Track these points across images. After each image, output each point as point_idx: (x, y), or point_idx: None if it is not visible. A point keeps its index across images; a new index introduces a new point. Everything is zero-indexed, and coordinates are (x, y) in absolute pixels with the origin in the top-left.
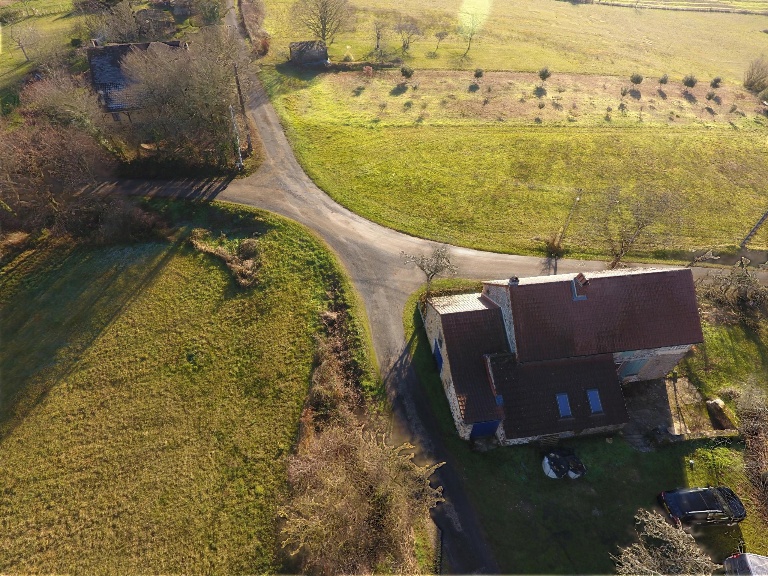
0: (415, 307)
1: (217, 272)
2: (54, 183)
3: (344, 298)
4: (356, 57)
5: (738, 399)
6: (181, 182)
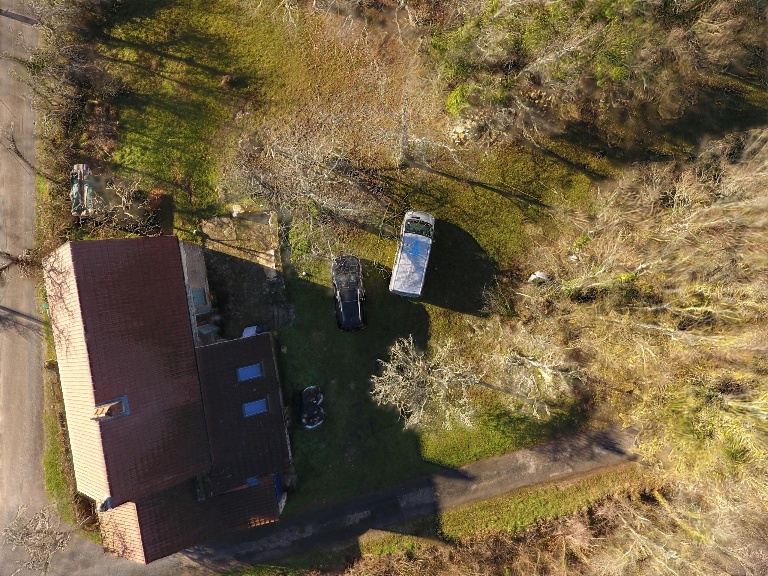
0: None
1: None
2: None
3: None
4: None
5: None
6: None
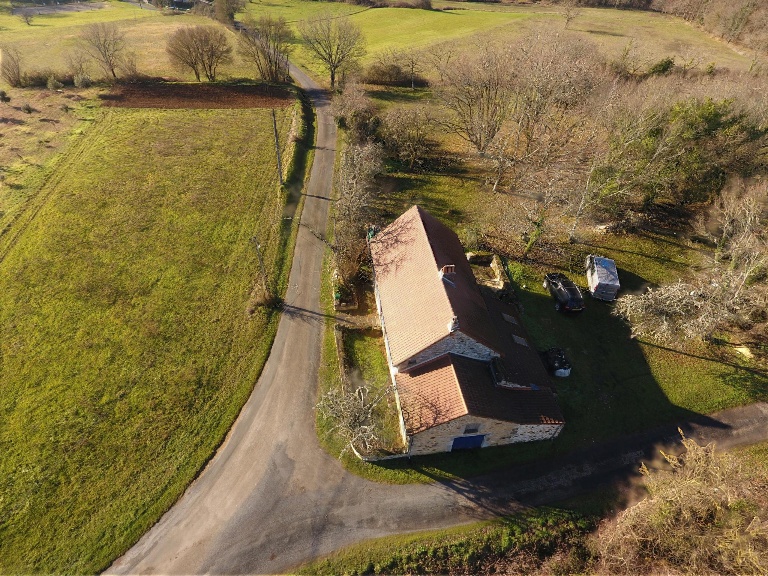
0: (373, 465)
1: None
2: None
3: (352, 575)
4: None
5: (468, 244)
6: None
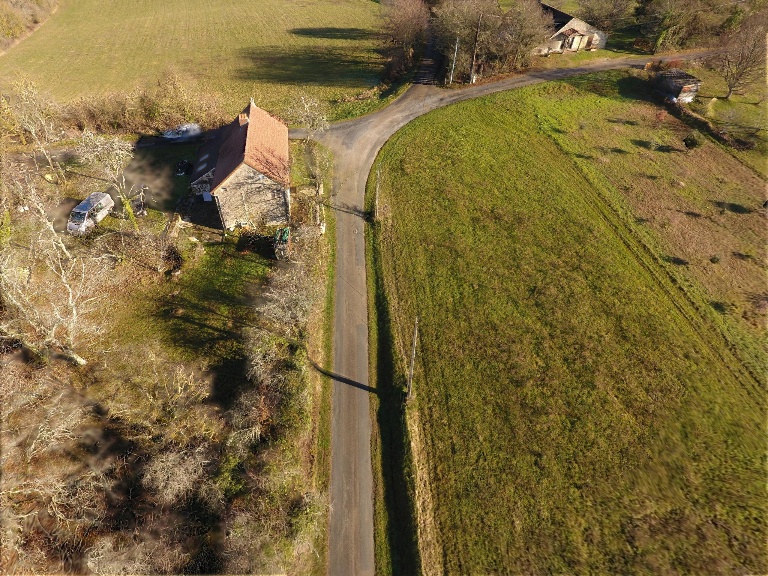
0: None
1: (351, 96)
2: (433, 53)
3: None
4: (722, 118)
5: None
6: (434, 75)
